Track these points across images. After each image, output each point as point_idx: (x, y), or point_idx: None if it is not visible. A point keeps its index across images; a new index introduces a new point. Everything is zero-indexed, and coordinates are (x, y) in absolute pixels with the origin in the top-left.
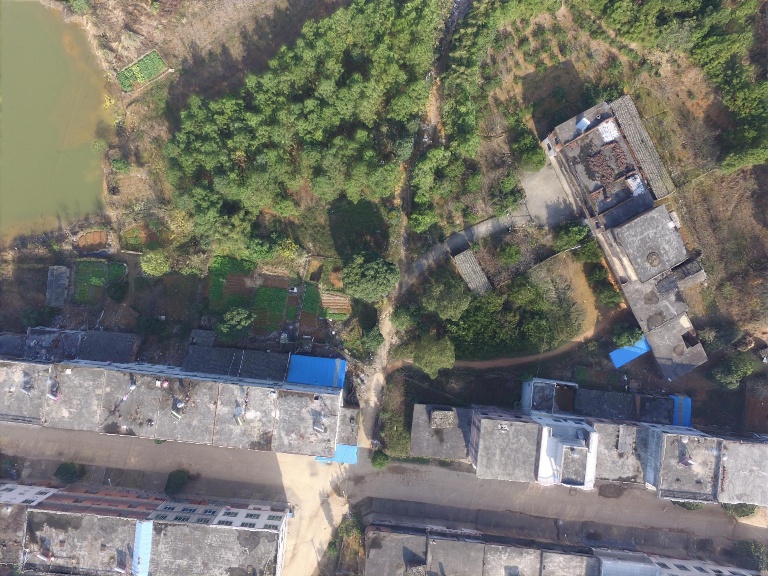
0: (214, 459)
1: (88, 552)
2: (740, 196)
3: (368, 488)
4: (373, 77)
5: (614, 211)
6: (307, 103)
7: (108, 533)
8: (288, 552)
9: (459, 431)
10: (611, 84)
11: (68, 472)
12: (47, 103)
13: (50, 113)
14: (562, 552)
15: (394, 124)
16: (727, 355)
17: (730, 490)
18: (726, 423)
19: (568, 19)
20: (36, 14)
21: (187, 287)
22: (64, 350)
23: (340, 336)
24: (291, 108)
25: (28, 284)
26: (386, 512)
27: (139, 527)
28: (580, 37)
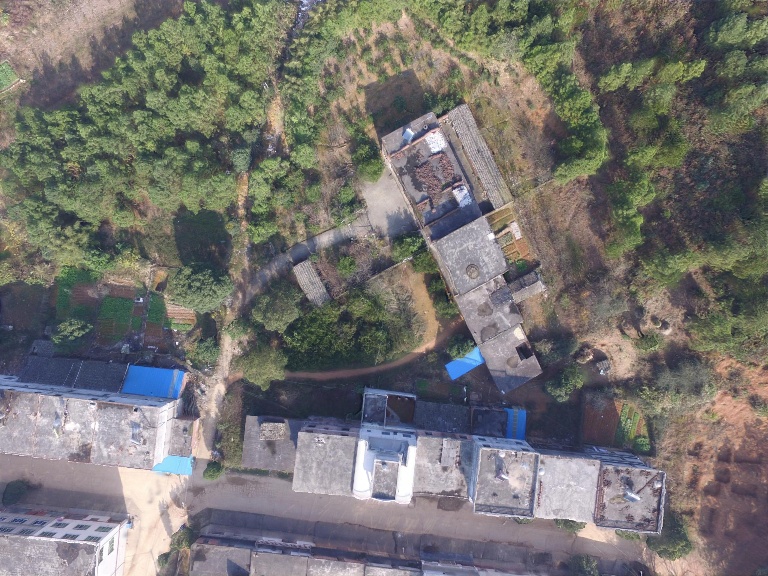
0: (56, 469)
1: None
2: (577, 206)
3: (207, 499)
4: (207, 88)
5: (441, 222)
6: (135, 114)
7: None
8: (127, 563)
9: (291, 443)
10: (450, 93)
11: None
12: None
13: None
14: (389, 566)
15: (235, 134)
16: (567, 367)
17: (547, 505)
18: (565, 436)
19: (410, 28)
20: None
21: (35, 297)
22: None
23: (183, 346)
24: None
25: None
26: (224, 524)
27: None
28: (421, 46)
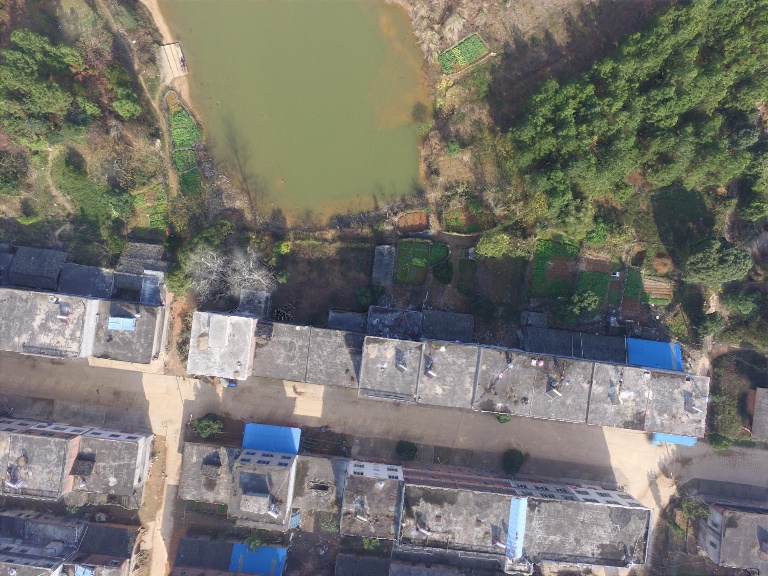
0: (543, 439)
1: (463, 527)
2: None
3: (695, 470)
4: (723, 66)
5: None
6: (671, 90)
7: (483, 509)
8: None
9: None
10: None
11: (411, 449)
12: (363, 83)
13: (366, 93)
14: None
15: (727, 113)
16: None
17: None
18: None
19: None
20: None
21: (509, 269)
22: (406, 329)
23: (665, 321)
24: (651, 94)
25: (350, 263)
26: (714, 493)
27: (516, 503)
28: None
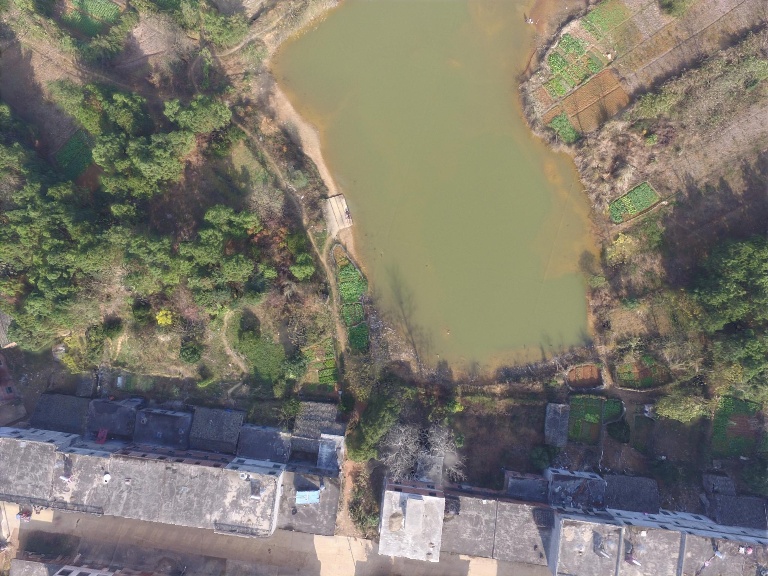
0: None
1: None
2: None
3: None
4: None
5: None
6: None
7: None
8: None
9: None
10: None
11: None
12: (528, 232)
13: (531, 242)
14: None
15: None
16: None
17: None
18: None
19: None
20: (517, 141)
21: (686, 426)
22: (590, 497)
23: None
24: None
25: (521, 419)
26: None
27: None
28: None
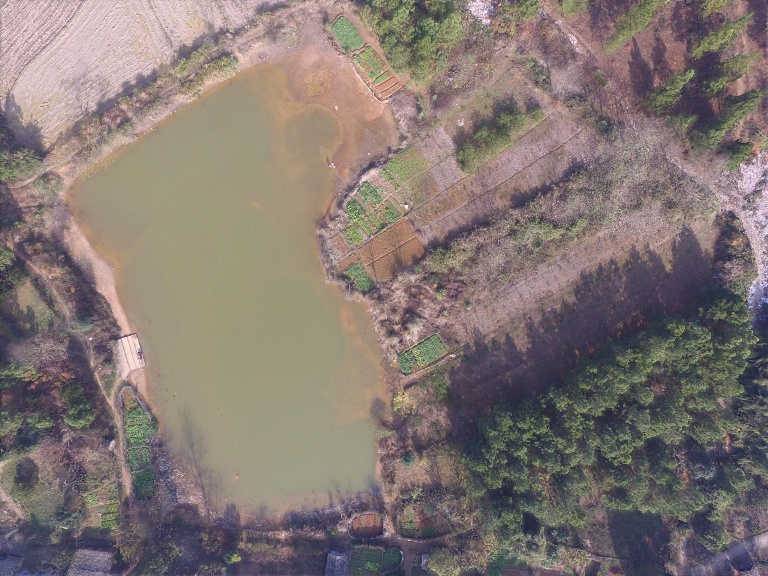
0: None
1: None
2: None
3: None
4: (679, 401)
5: None
6: (624, 436)
7: None
8: None
9: None
10: None
11: None
12: (321, 377)
13: (324, 387)
14: None
15: None
16: None
17: None
18: None
19: None
20: (314, 286)
21: None
22: None
23: None
24: (605, 437)
25: (302, 567)
26: None
27: None
28: None
